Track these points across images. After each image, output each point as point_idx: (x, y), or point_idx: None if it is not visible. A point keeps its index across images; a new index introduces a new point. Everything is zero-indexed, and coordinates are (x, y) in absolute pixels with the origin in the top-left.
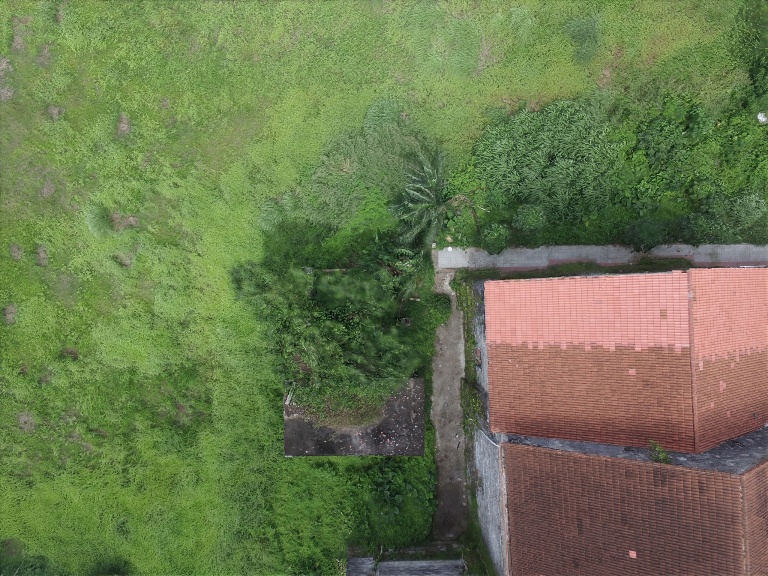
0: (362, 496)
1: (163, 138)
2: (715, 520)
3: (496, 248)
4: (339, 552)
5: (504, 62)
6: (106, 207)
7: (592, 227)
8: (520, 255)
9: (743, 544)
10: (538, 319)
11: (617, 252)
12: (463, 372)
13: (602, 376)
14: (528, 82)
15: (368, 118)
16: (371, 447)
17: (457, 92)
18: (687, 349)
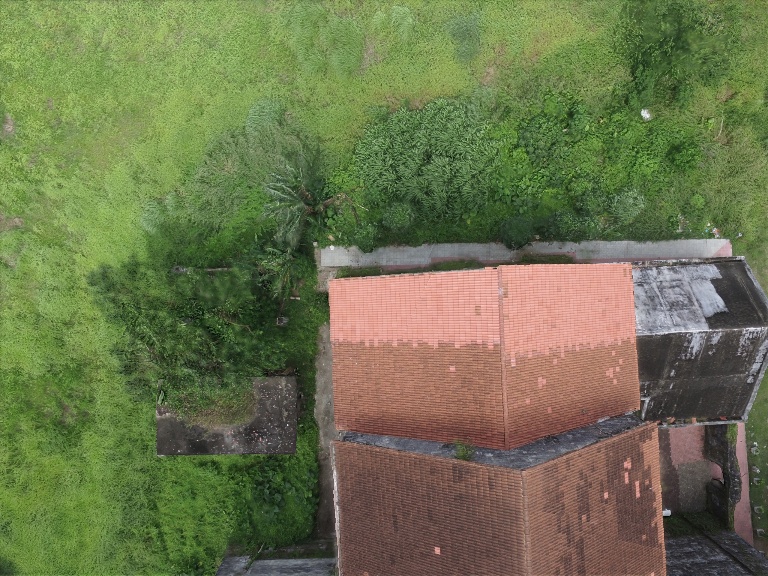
0: (245, 495)
1: (48, 139)
2: (502, 516)
3: (365, 246)
4: (222, 551)
5: (387, 60)
6: None
7: (474, 225)
8: (403, 253)
9: (524, 539)
10: (374, 317)
11: (499, 249)
12: None
13: (427, 373)
14: (411, 80)
15: (249, 117)
16: (243, 446)
17: (340, 91)
18: (498, 345)
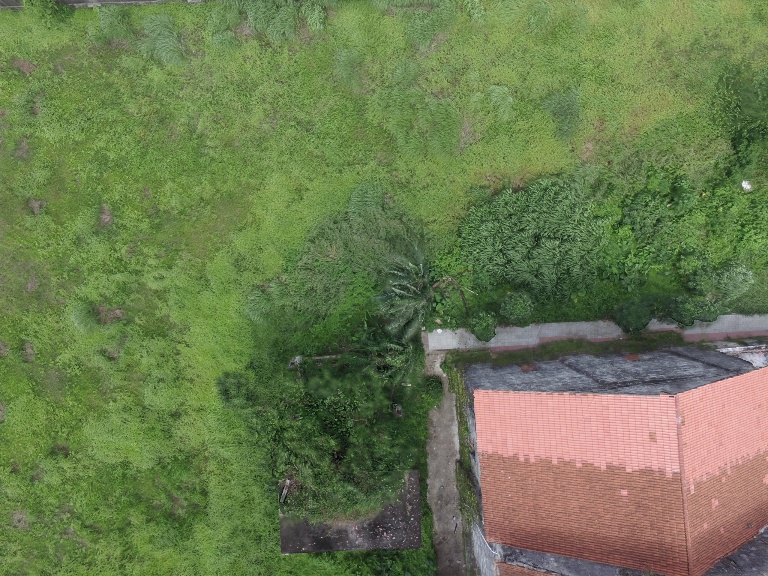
0: None
1: (146, 228)
2: None
3: (485, 338)
4: None
5: (487, 140)
6: (92, 301)
7: (581, 303)
8: (510, 334)
9: None
10: (528, 432)
11: (607, 327)
12: (458, 454)
13: (594, 494)
14: (511, 159)
15: (352, 203)
16: (368, 541)
17: (441, 172)
18: (677, 474)
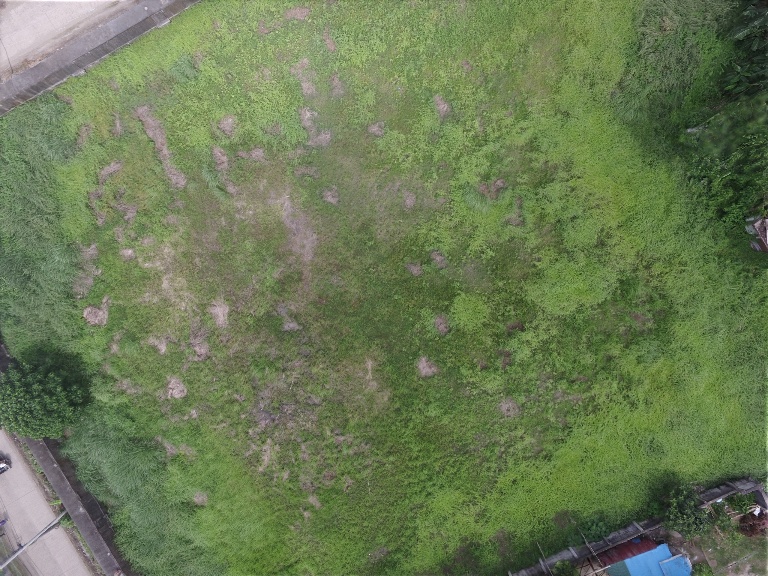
0: None
1: (485, 97)
2: None
3: None
4: None
5: None
6: (471, 184)
7: None
8: None
9: None
10: None
11: None
12: None
13: None
14: None
15: None
16: None
17: None
18: None
